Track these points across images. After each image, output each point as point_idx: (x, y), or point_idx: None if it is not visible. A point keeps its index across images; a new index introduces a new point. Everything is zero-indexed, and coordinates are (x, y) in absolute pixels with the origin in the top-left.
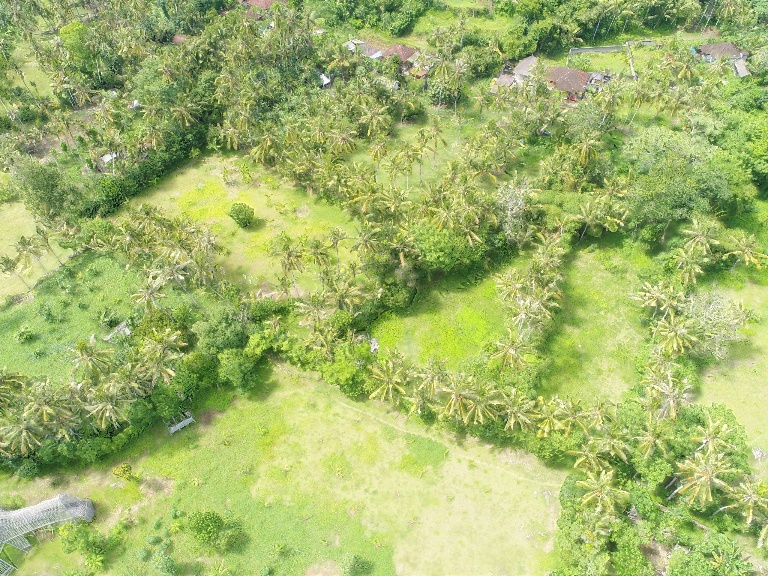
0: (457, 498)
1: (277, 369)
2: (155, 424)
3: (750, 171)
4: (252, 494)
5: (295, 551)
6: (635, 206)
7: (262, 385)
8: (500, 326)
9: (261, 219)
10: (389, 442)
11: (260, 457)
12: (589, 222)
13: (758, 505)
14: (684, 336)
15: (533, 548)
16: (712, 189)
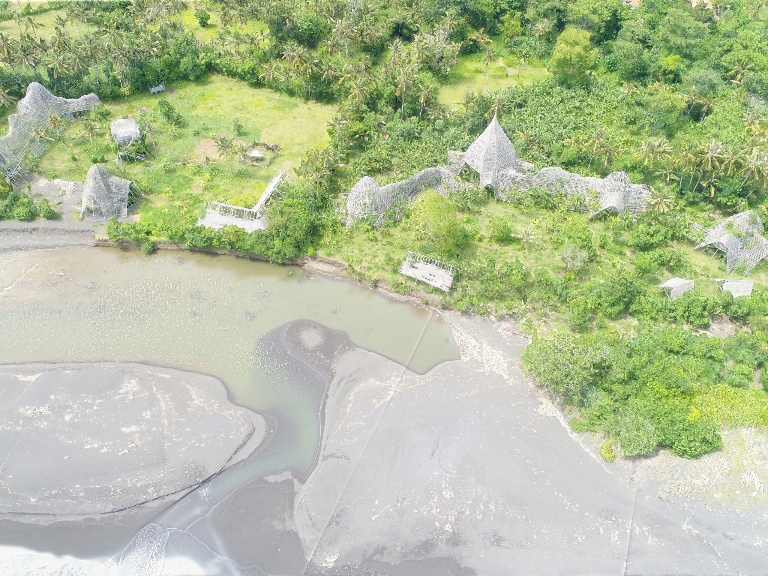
0: (298, 118)
1: (213, 77)
2: (143, 91)
3: (498, 8)
4: (193, 114)
5: (211, 127)
6: (422, 11)
7: (204, 81)
8: None
9: (214, 24)
10: (268, 101)
11: (199, 103)
12: (400, 22)
13: (428, 97)
14: (422, 51)
15: None
16: (464, 3)
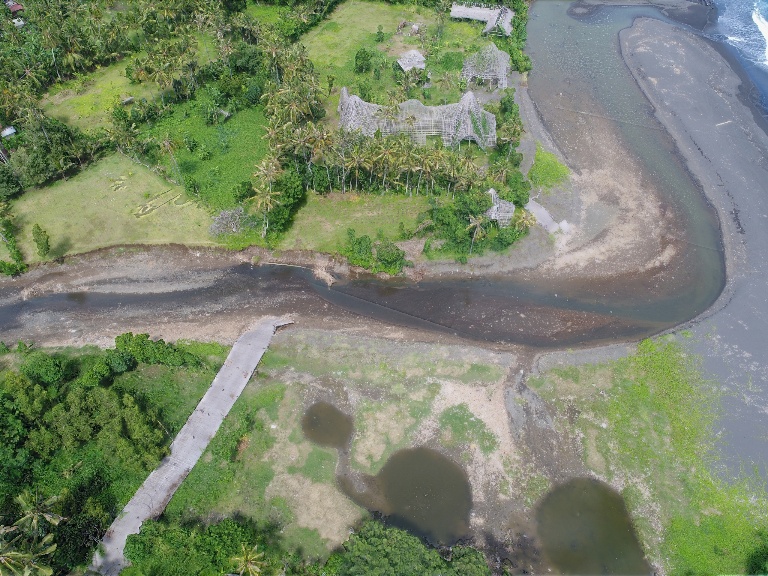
0: None
1: None
2: None
3: None
4: None
5: None
6: None
7: None
8: (268, 8)
9: None
10: (324, 34)
11: None
12: None
13: None
14: None
15: (376, 8)
16: None
